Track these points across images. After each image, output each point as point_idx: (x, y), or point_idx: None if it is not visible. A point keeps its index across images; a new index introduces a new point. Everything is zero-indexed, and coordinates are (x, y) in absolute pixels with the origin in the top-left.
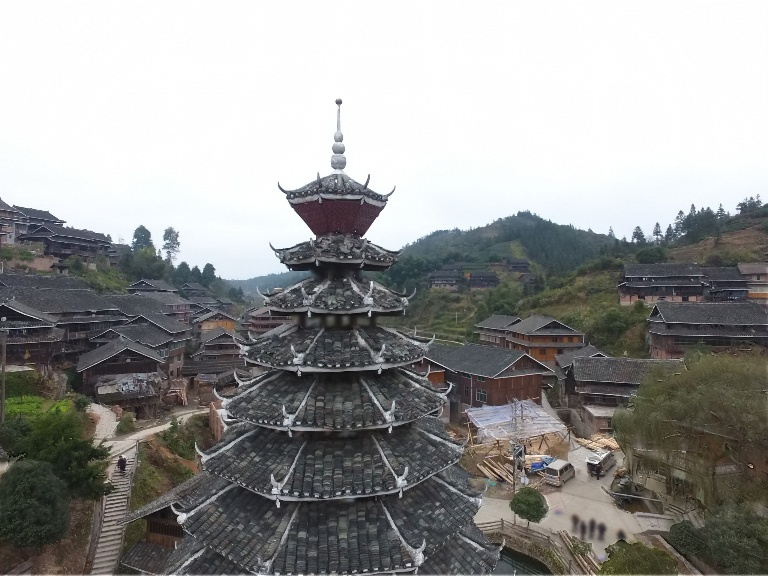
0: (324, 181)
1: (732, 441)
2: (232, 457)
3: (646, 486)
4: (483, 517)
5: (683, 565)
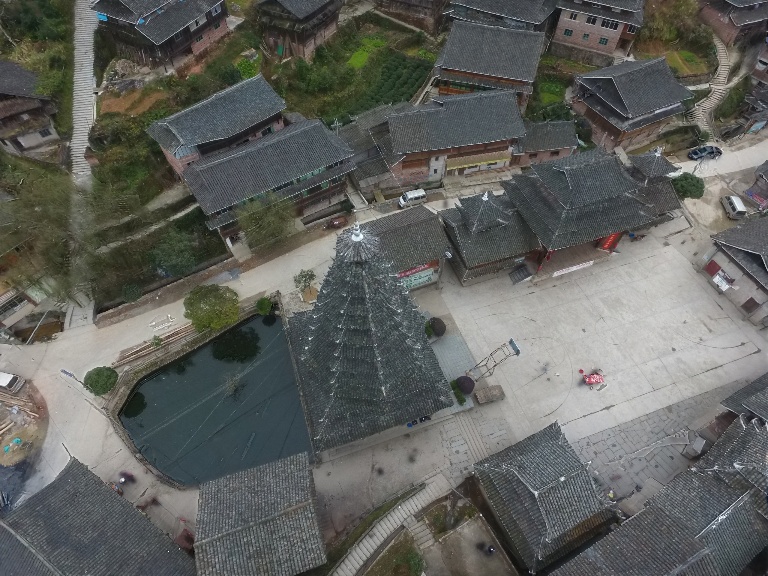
0: (367, 240)
1: (23, 242)
2: (401, 314)
3: (17, 320)
4: (89, 430)
5: (132, 305)
